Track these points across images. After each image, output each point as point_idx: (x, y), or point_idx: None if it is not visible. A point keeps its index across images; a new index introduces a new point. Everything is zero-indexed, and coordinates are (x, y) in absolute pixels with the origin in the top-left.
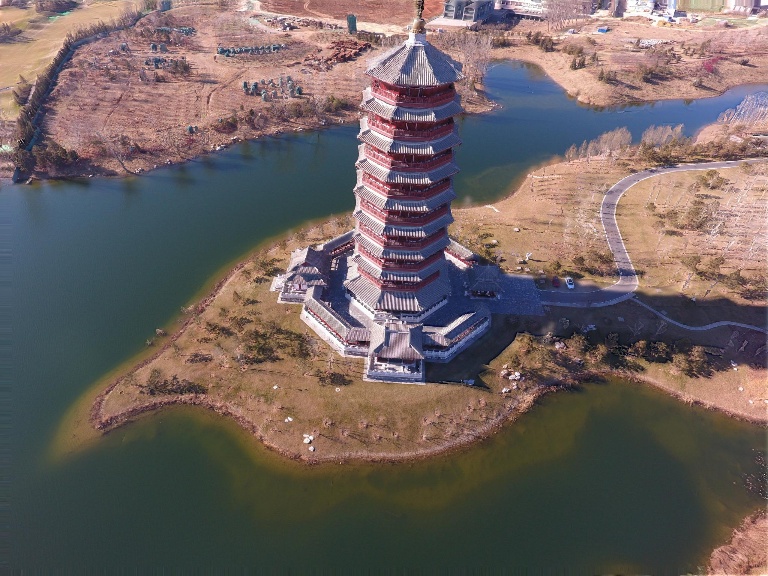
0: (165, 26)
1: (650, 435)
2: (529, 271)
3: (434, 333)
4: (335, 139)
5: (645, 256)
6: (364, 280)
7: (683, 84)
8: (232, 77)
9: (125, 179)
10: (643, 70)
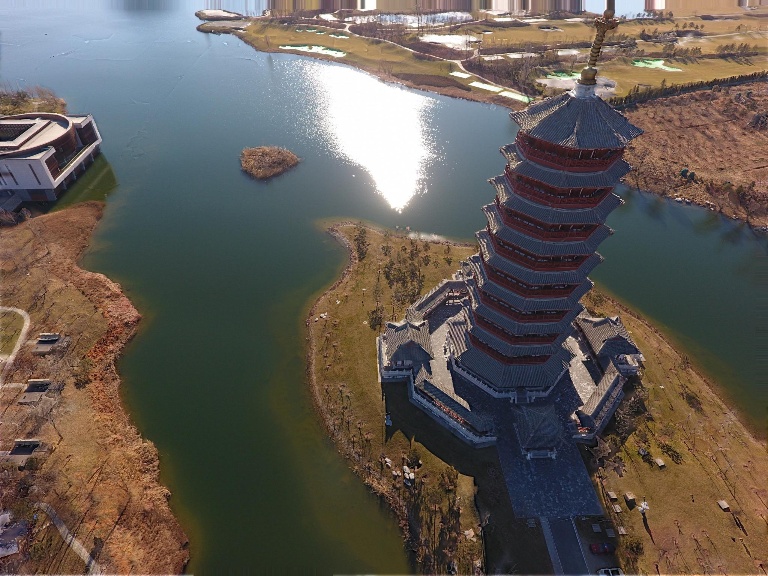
0: None
1: None
2: (614, 510)
3: (429, 373)
4: None
5: None
6: None
7: None
8: None
9: None
10: None
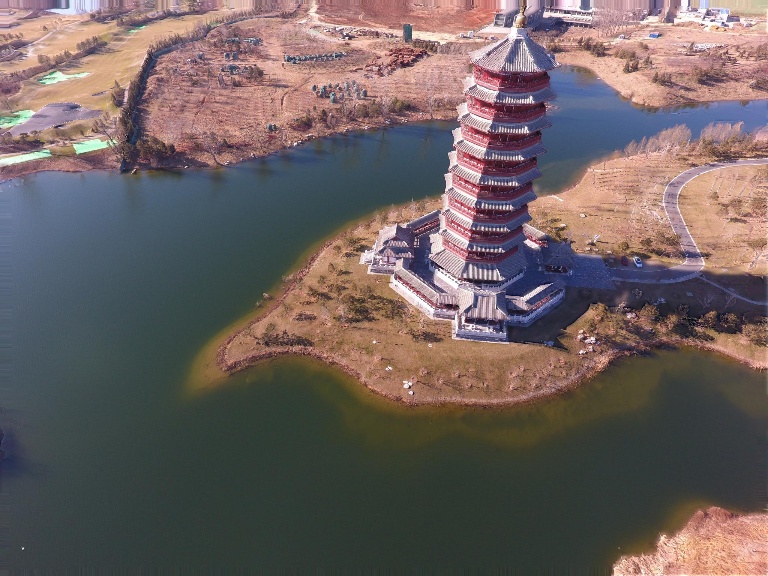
0: (233, 37)
1: (722, 395)
2: (598, 251)
3: (516, 299)
4: (400, 137)
5: (710, 240)
6: (448, 253)
7: (739, 86)
8: (301, 82)
9: (216, 170)
10: (698, 72)
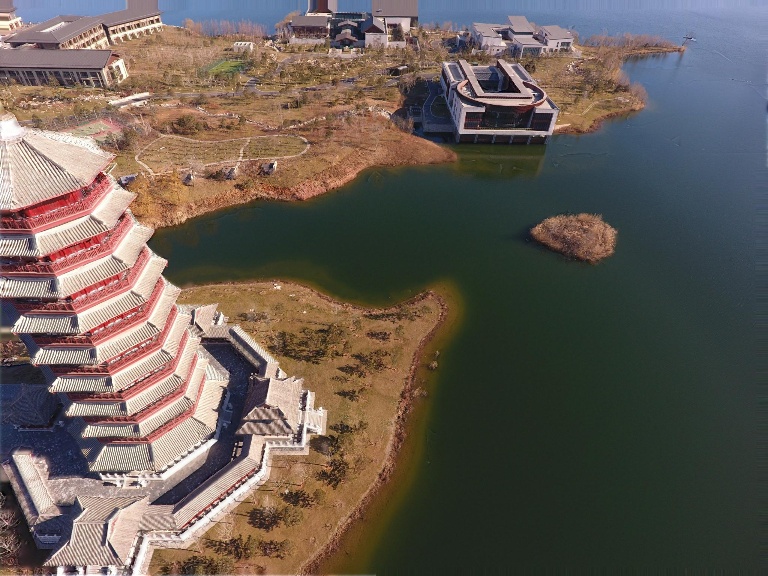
0: None
1: None
2: None
3: None
4: None
5: None
6: None
7: None
8: None
9: None
10: None
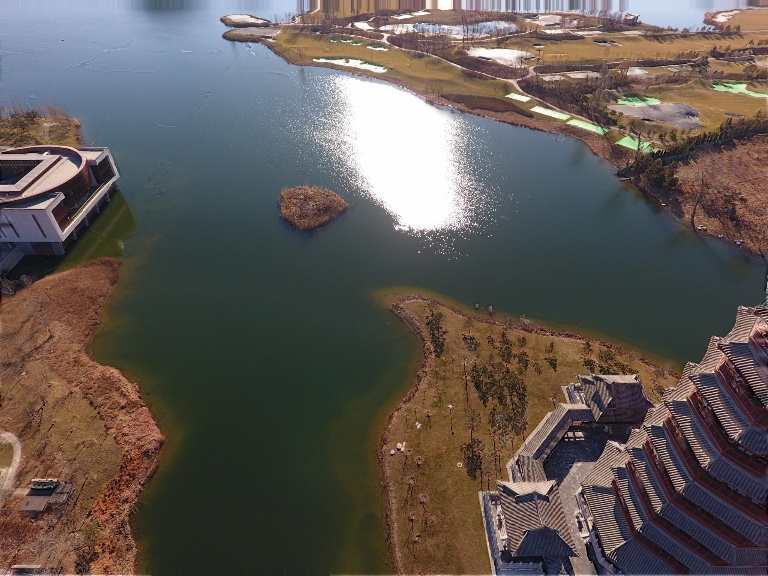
0: None
1: None
2: None
3: None
4: None
5: None
6: None
7: None
8: None
9: (680, 225)
10: None
